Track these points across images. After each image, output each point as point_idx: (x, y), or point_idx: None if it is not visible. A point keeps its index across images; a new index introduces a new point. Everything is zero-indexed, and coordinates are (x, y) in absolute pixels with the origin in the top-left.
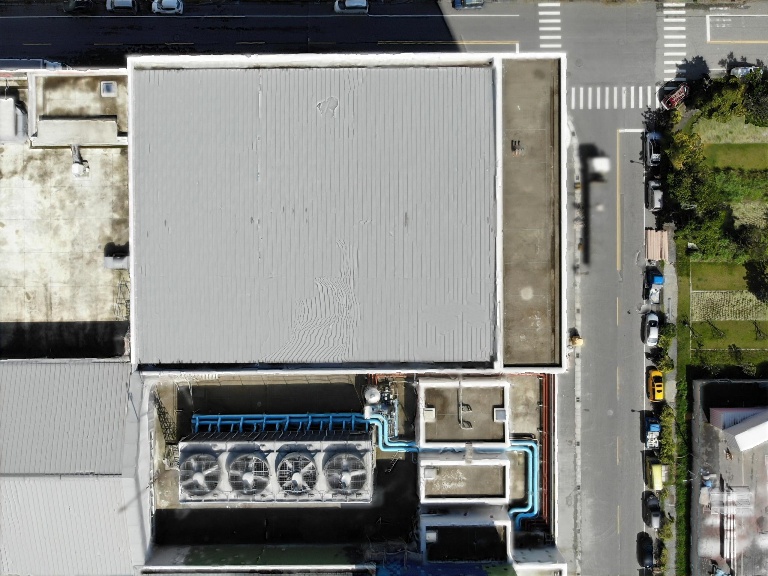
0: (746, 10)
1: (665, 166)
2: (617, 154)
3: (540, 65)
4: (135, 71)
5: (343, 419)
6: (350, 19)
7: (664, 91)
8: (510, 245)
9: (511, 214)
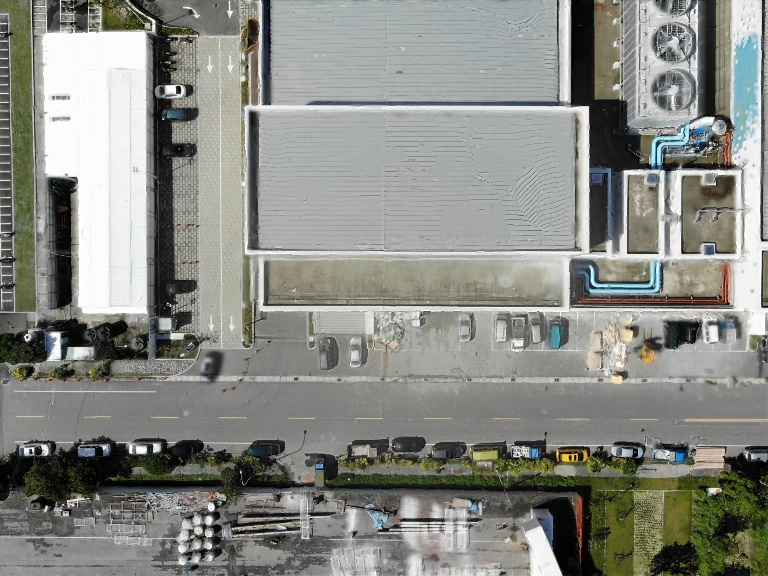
0: None
1: None
2: None
3: None
4: None
5: None
6: None
7: None
8: None
9: None
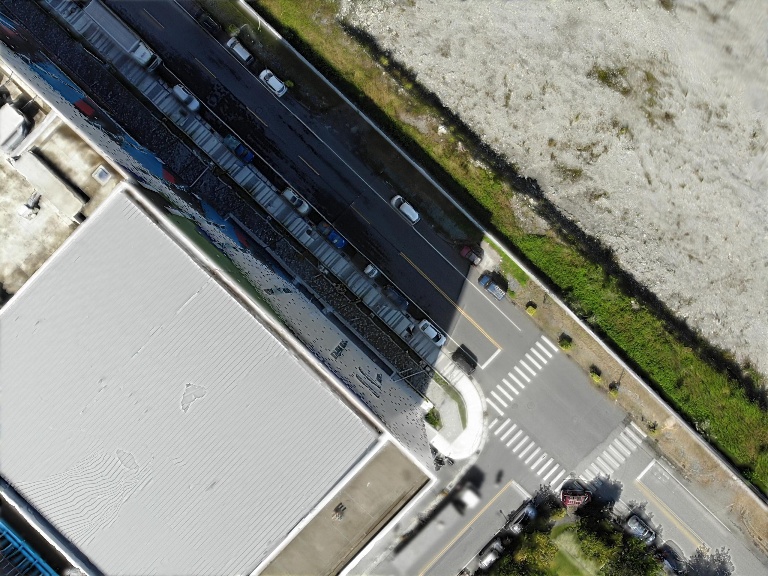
0: (687, 482)
1: (519, 540)
2: (496, 496)
3: (413, 468)
4: (120, 193)
5: (44, 570)
6: (397, 216)
7: (572, 483)
8: (268, 575)
9: (290, 554)
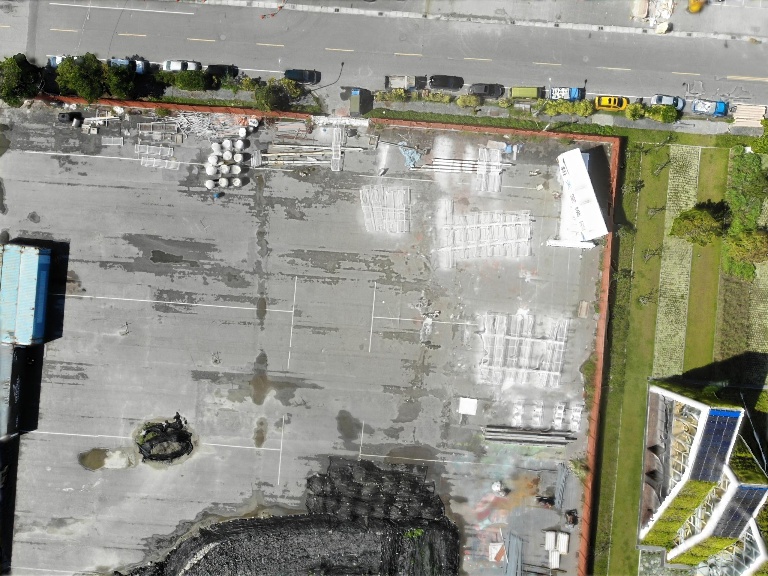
0: None
1: None
2: None
3: None
4: None
5: None
6: None
7: None
8: None
9: None
